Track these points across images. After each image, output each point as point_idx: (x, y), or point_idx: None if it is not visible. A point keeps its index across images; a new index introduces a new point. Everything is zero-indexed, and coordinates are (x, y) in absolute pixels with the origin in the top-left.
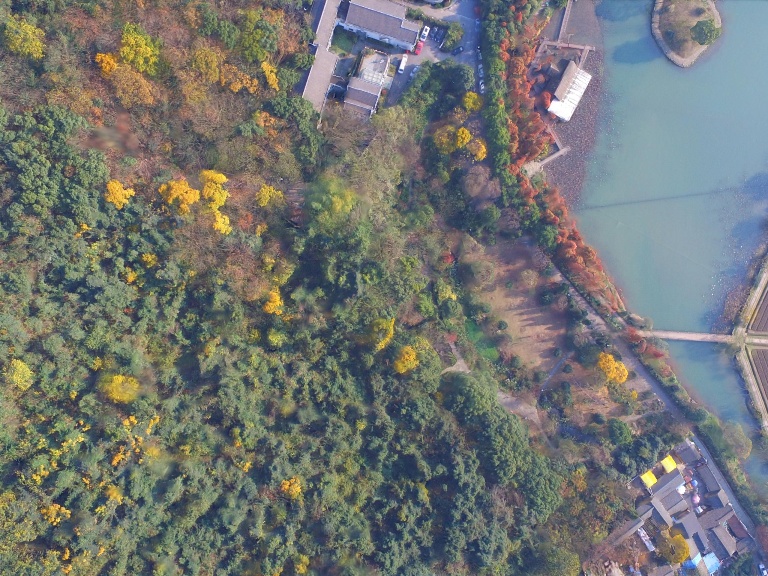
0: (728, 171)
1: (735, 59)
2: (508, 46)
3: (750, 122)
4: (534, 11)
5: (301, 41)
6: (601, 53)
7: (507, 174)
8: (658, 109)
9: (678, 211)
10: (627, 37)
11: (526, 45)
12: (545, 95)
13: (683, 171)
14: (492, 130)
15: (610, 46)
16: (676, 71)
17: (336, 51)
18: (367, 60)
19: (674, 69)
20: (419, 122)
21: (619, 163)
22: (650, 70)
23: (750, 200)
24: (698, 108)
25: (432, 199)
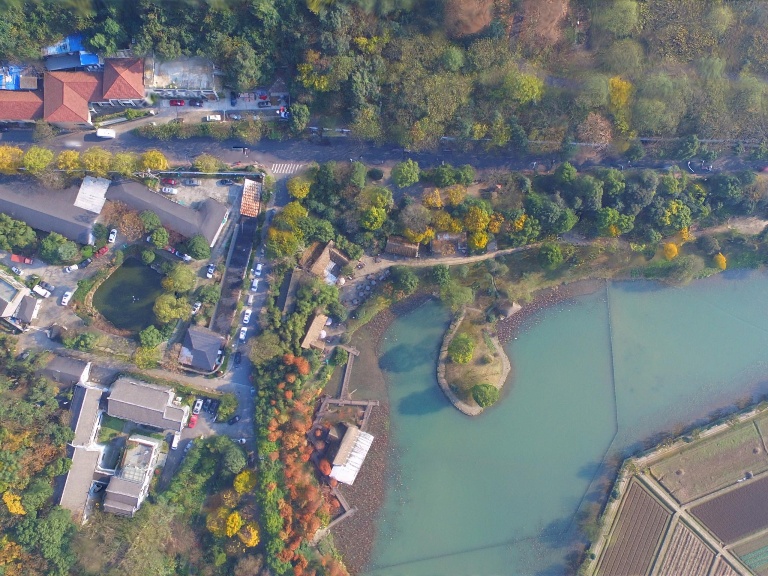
0: (524, 519)
1: (528, 400)
2: (278, 424)
3: (543, 470)
4: (312, 373)
5: (57, 445)
6: (386, 407)
7: (278, 565)
8: (449, 459)
9: (474, 564)
10: (413, 388)
11: (297, 421)
12: (322, 467)
13: (479, 519)
14: (263, 516)
15: (395, 398)
16: (465, 419)
17: (105, 434)
18: (131, 452)
19: (463, 417)
20: (195, 500)
21: (410, 518)
22: (439, 418)
23: (548, 549)
24: (491, 455)
25: (213, 575)
